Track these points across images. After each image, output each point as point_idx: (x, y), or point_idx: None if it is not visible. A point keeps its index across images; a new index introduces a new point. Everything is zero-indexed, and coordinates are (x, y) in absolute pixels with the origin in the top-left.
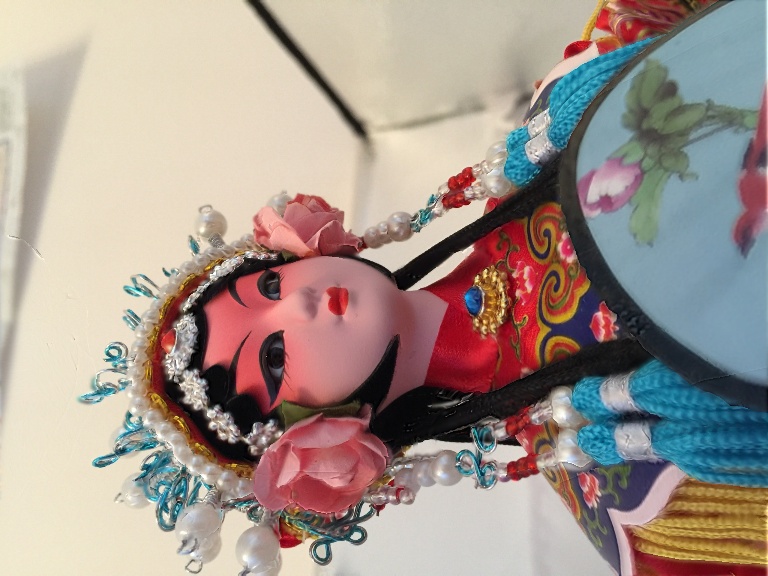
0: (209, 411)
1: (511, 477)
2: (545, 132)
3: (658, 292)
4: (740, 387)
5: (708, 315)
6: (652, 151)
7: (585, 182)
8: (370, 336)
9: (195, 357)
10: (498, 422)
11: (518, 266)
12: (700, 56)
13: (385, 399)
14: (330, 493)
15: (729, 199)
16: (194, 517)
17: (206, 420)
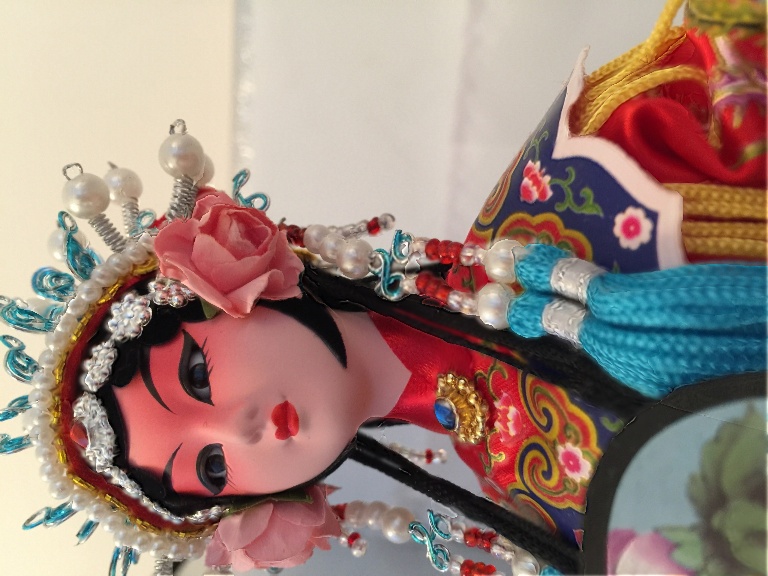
0: (145, 497)
1: None
2: (576, 327)
3: None
4: None
5: None
6: (715, 572)
7: (620, 542)
8: (325, 453)
9: (117, 458)
10: (456, 519)
11: (503, 399)
12: None
13: None
14: None
15: None
16: None
17: None
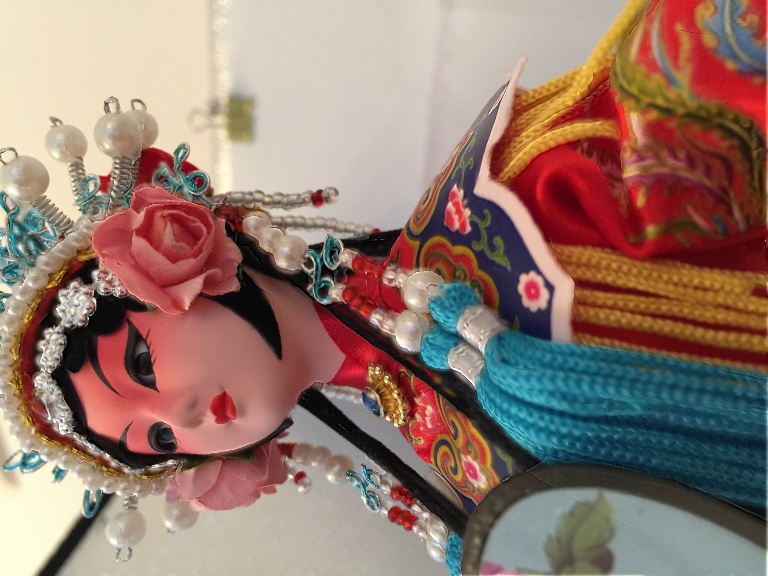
0: None
1: None
2: (473, 378)
3: None
4: None
5: None
6: None
7: (489, 570)
8: (263, 430)
9: (77, 428)
10: (385, 475)
11: (421, 398)
12: (651, 557)
13: None
14: None
15: None
16: (122, 529)
17: None
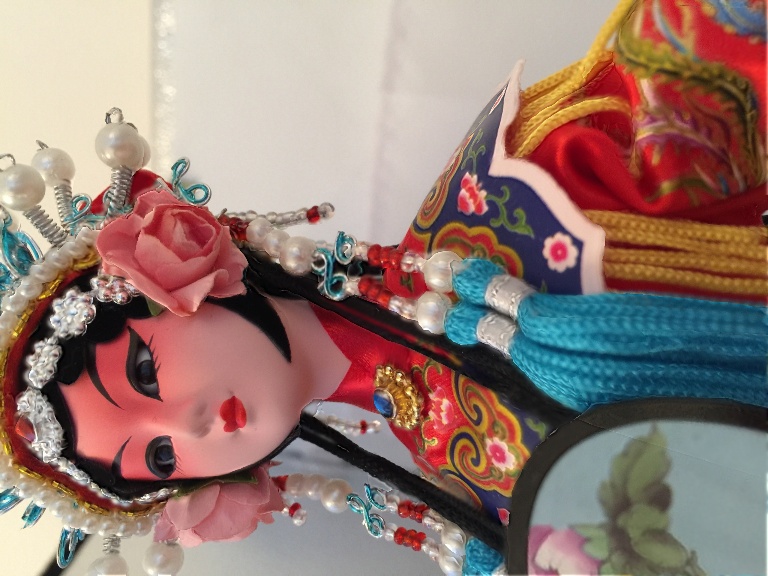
0: (93, 483)
1: (397, 542)
2: (507, 342)
3: None
4: None
5: None
6: (617, 561)
7: (539, 534)
8: (270, 441)
9: (65, 450)
10: (391, 492)
11: (437, 391)
12: (711, 483)
13: None
14: None
15: None
16: (103, 575)
17: None
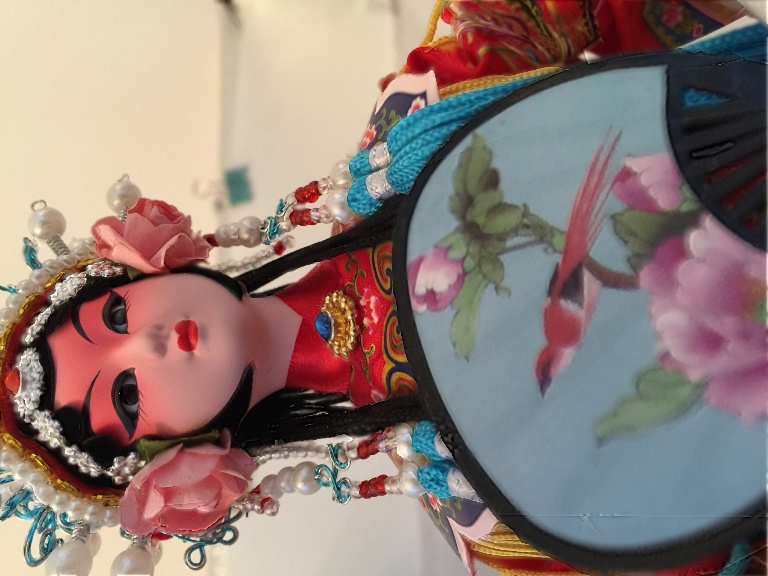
0: (67, 448)
1: (363, 496)
2: (384, 173)
3: (470, 414)
4: (529, 529)
5: (509, 450)
6: (473, 250)
7: (414, 268)
8: (223, 369)
9: (44, 398)
10: (351, 441)
11: (365, 294)
12: (521, 147)
13: (246, 411)
14: (198, 511)
15: (534, 328)
16: (63, 558)
17: (65, 455)
